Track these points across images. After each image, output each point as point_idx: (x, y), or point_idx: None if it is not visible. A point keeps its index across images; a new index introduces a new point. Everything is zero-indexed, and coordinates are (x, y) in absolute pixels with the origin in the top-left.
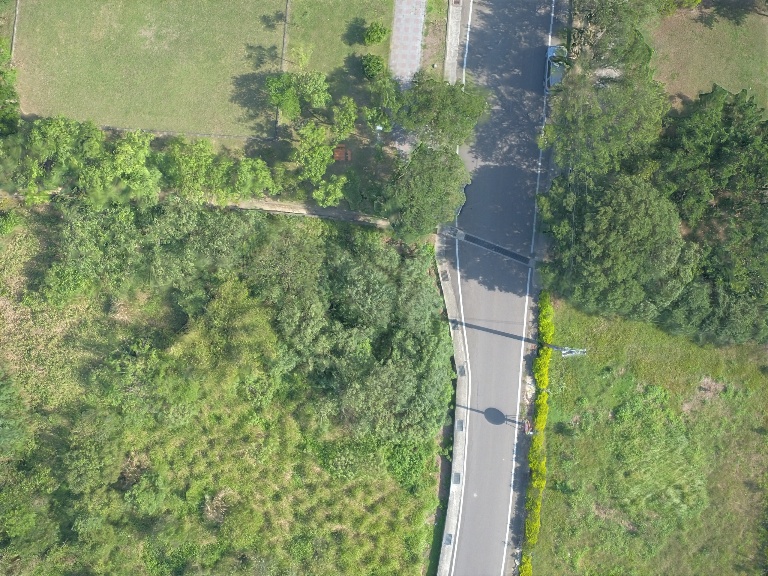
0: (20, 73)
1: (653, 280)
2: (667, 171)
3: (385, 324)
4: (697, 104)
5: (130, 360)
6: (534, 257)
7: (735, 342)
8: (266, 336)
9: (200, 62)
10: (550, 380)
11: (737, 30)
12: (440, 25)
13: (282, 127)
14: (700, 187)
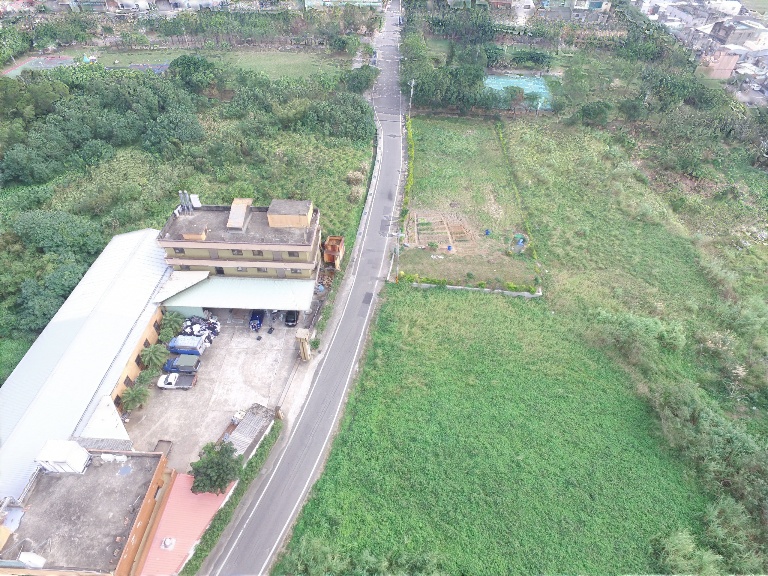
0: None
1: (436, 84)
2: None
3: None
4: None
5: (255, 110)
6: None
7: None
8: None
9: None
10: (412, 130)
11: None
12: None
13: None
14: None
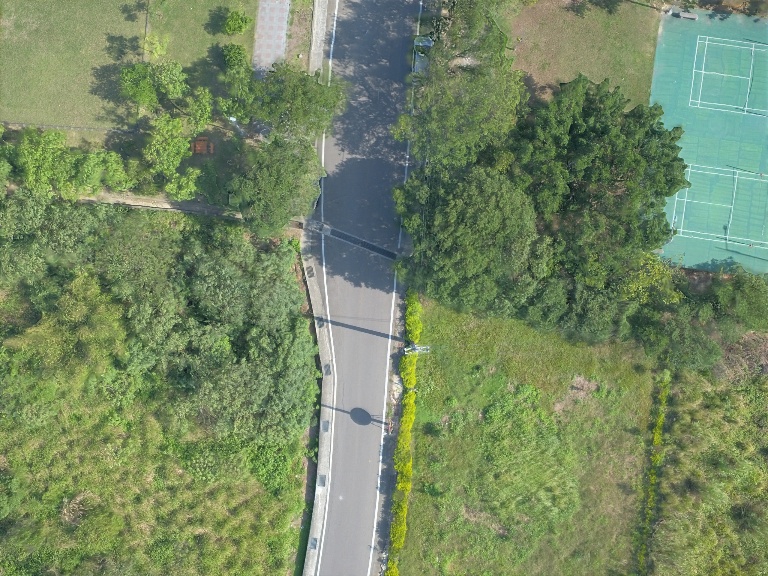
0: None
1: (505, 275)
2: (523, 163)
3: (240, 321)
4: None
5: None
6: (401, 252)
7: (607, 340)
8: (115, 334)
9: (60, 52)
10: (418, 379)
11: (609, 19)
12: (306, 14)
13: (144, 119)
14: (555, 179)
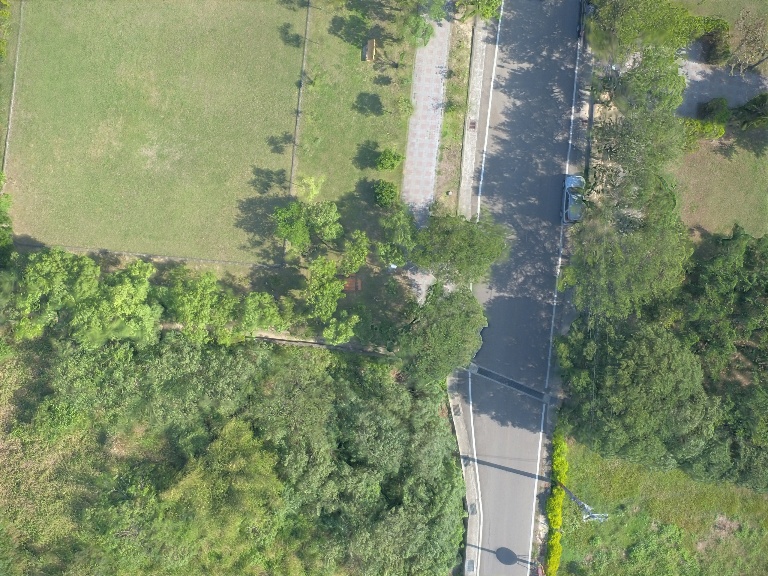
0: (12, 190)
1: (675, 436)
2: (689, 320)
3: (397, 469)
4: (716, 238)
5: (128, 505)
6: (549, 392)
7: None
8: (273, 483)
9: (204, 184)
10: (563, 519)
11: (757, 163)
12: (455, 150)
13: (290, 253)
14: (723, 340)
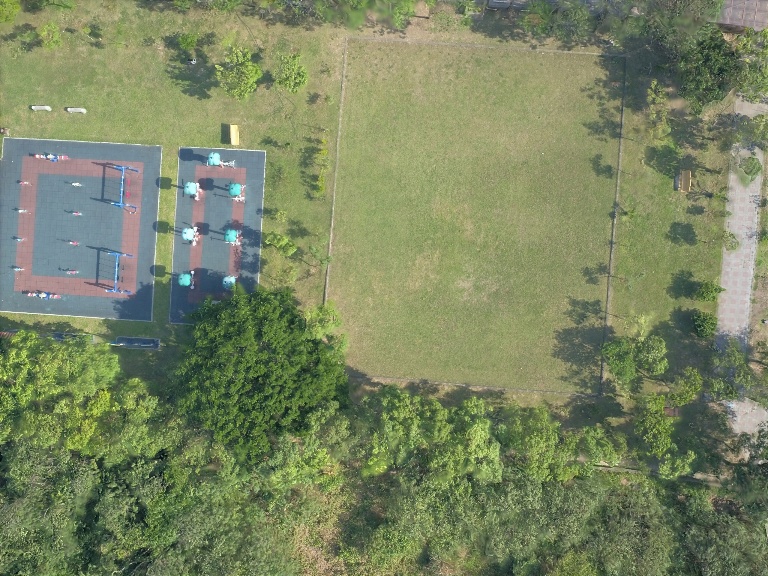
0: None
1: None
2: None
3: None
4: None
5: None
6: None
7: None
8: None
9: (521, 315)
10: None
11: None
12: None
13: (606, 382)
14: None
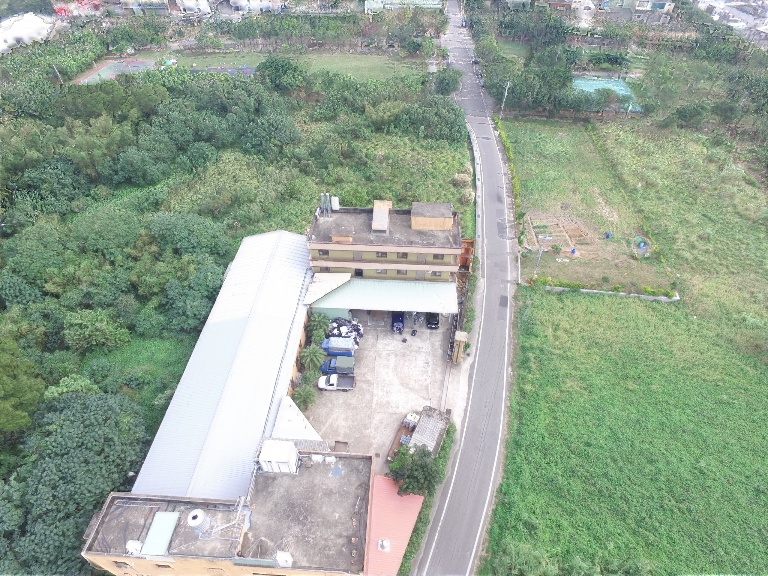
0: None
1: (527, 86)
2: None
3: None
4: None
5: (350, 113)
6: None
7: None
8: None
9: None
10: None
11: None
12: None
13: None
14: None
